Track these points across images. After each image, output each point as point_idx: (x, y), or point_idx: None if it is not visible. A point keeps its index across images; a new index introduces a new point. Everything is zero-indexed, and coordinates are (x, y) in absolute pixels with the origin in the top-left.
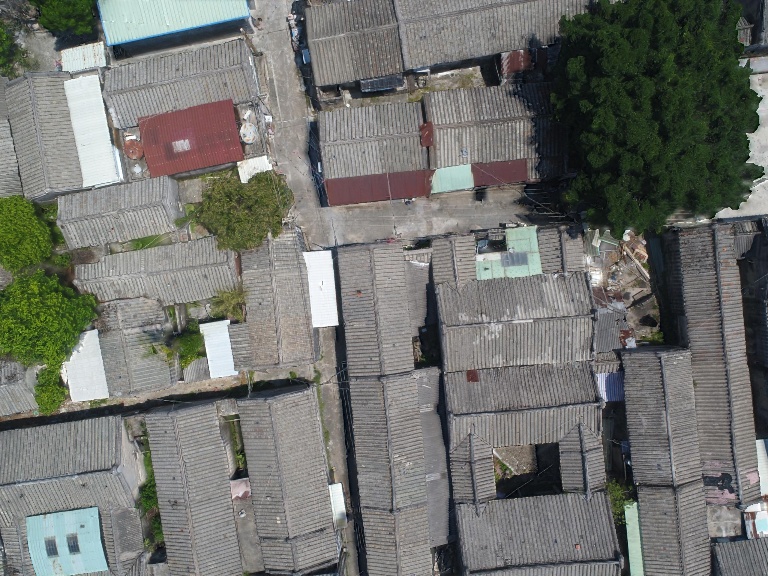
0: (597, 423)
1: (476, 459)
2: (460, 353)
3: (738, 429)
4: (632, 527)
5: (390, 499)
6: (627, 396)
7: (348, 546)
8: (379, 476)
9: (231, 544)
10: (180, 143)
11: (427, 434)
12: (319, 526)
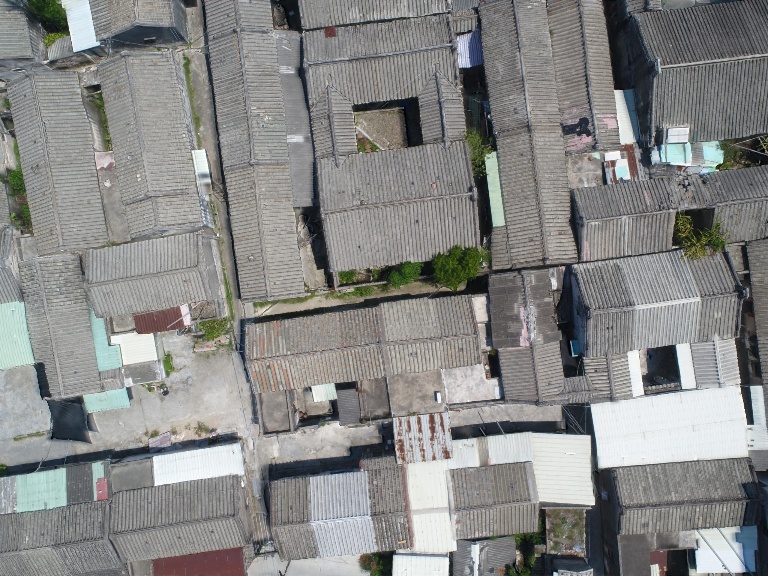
0: (454, 71)
1: (335, 112)
2: (316, 6)
3: (594, 73)
4: (492, 177)
5: (249, 151)
6: (484, 47)
7: (222, 232)
8: (238, 131)
9: (95, 210)
10: None
11: (288, 95)
12: (181, 186)
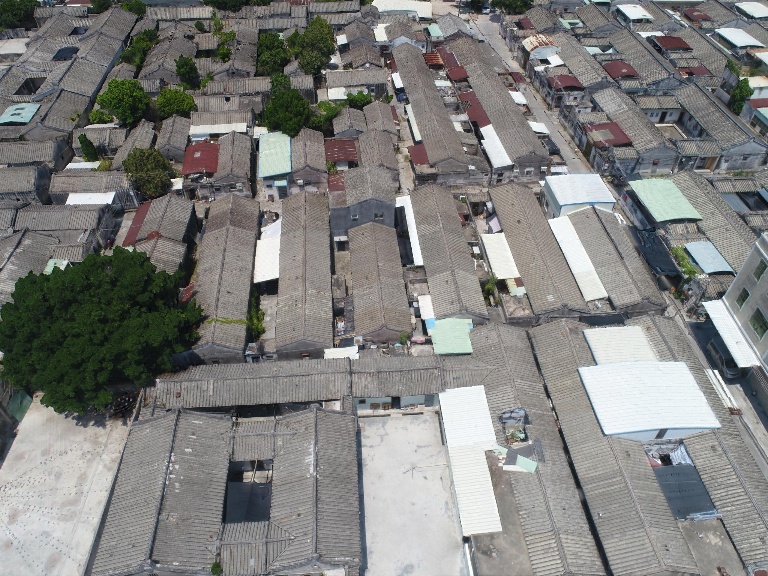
0: None
1: None
2: (7, 243)
3: None
4: None
5: None
6: None
7: None
8: None
9: None
10: (199, 154)
11: None
12: None
